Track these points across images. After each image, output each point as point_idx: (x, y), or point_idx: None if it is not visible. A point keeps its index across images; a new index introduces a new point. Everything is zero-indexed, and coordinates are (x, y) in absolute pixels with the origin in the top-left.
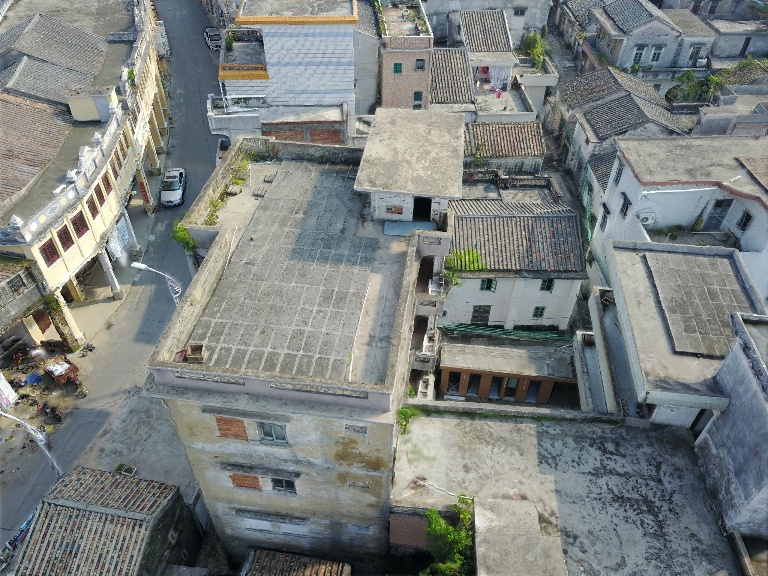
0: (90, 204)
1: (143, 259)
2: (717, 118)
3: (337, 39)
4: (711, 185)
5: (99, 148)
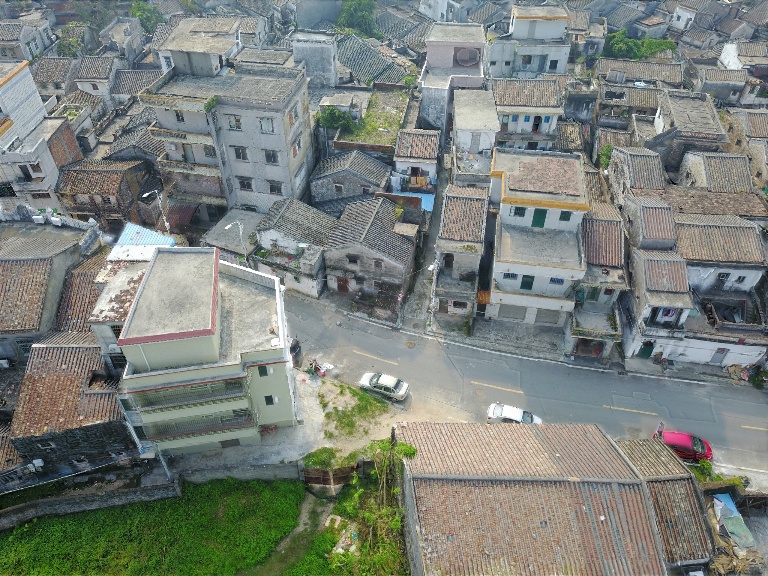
0: None
1: None
2: (127, 42)
3: (26, 78)
4: None
5: None
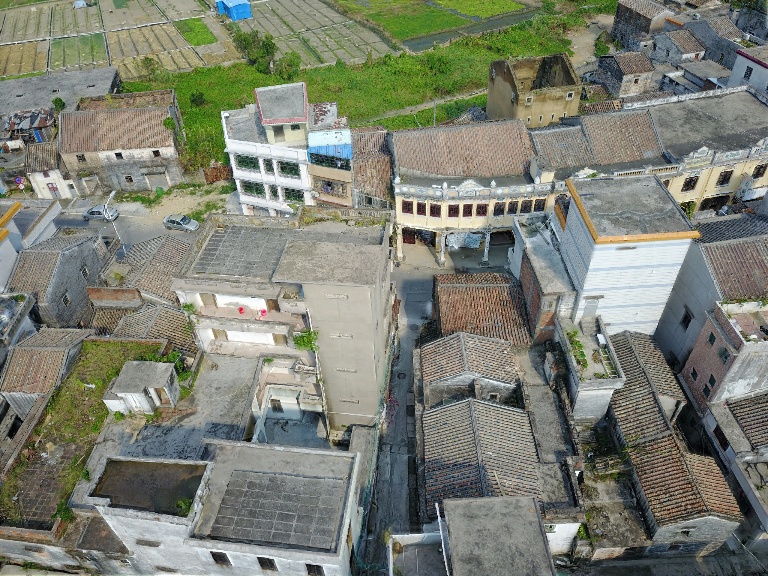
0: (454, 208)
1: (482, 268)
2: None
3: None
4: (451, 575)
5: (488, 189)
